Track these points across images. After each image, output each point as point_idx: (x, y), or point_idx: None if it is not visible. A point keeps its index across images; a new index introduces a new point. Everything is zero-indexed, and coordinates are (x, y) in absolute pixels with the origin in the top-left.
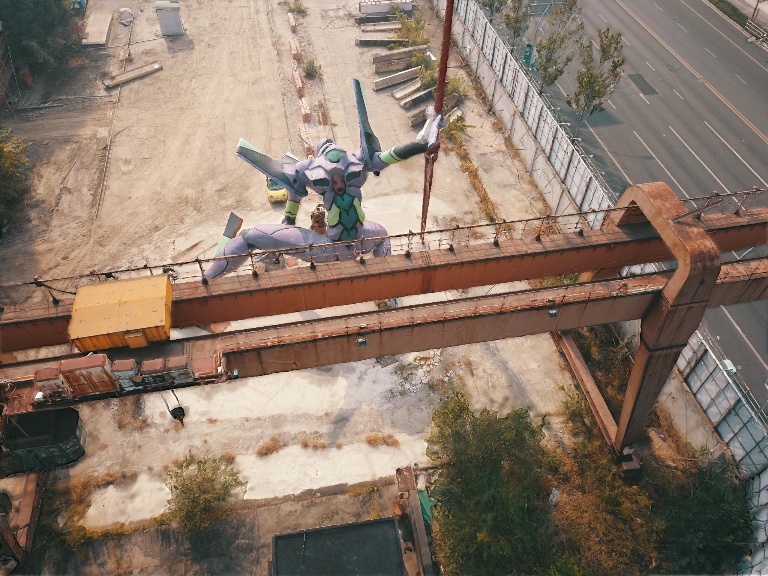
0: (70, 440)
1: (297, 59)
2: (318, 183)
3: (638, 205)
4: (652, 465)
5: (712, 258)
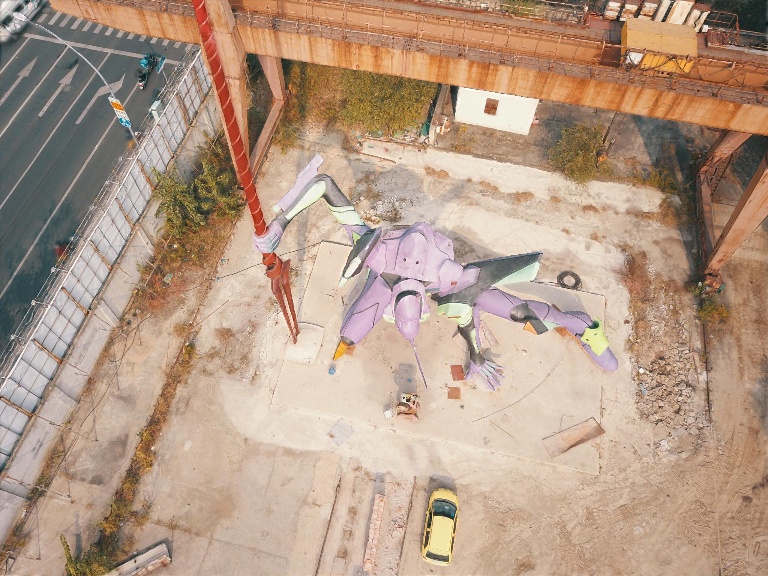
0: None
1: None
2: None
3: None
4: (268, 92)
5: None
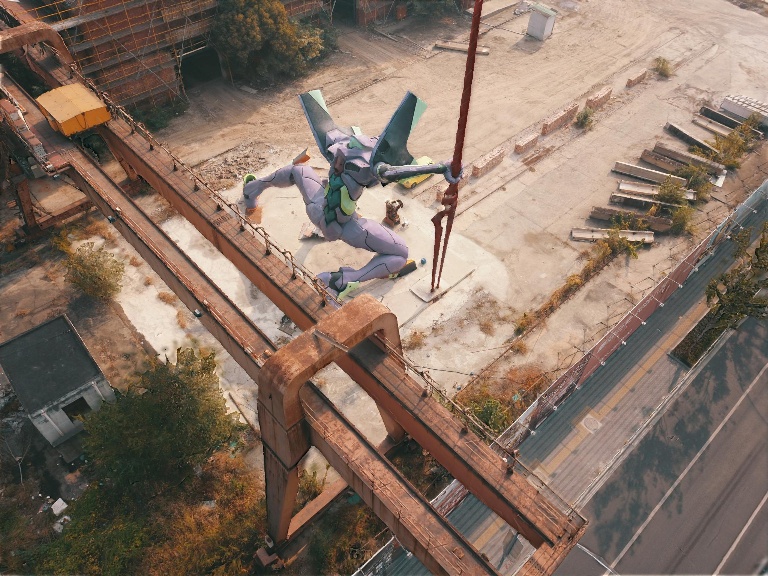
0: (24, 159)
1: (589, 106)
2: (330, 155)
3: None
4: None
5: (281, 380)
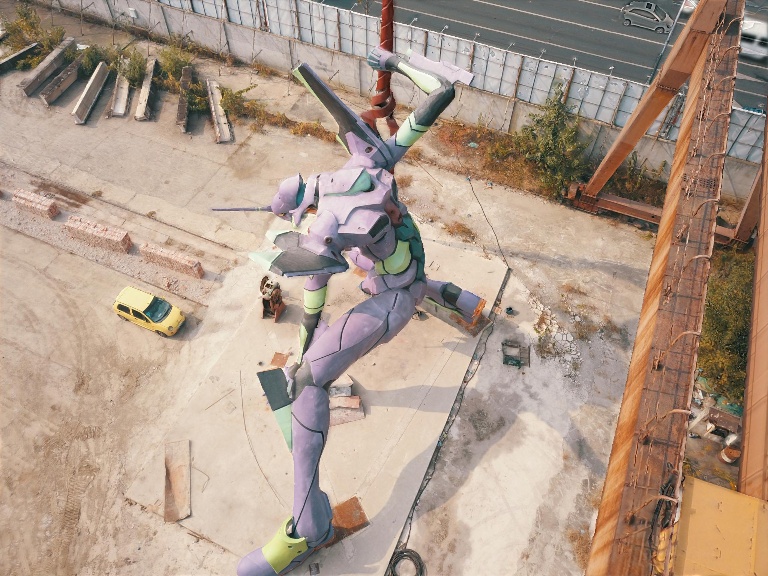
0: None
1: None
2: (374, 230)
3: None
4: None
5: None
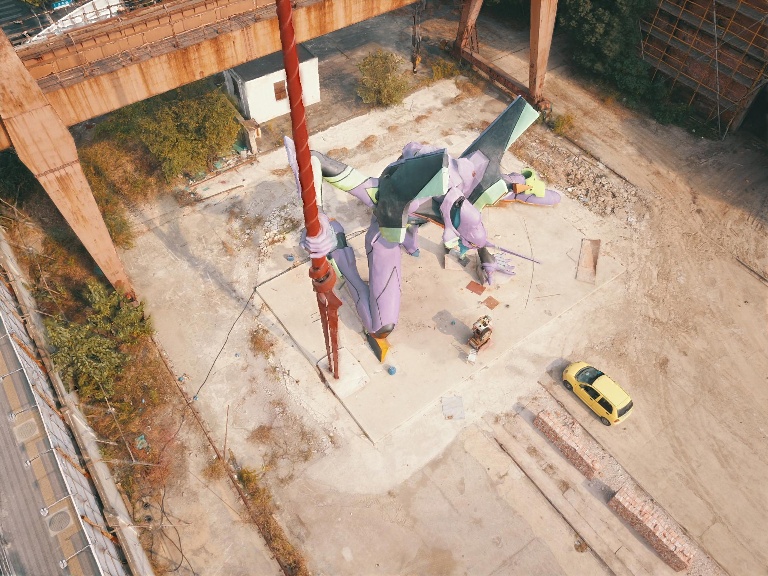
0: None
1: None
2: None
3: None
4: (48, 209)
5: None
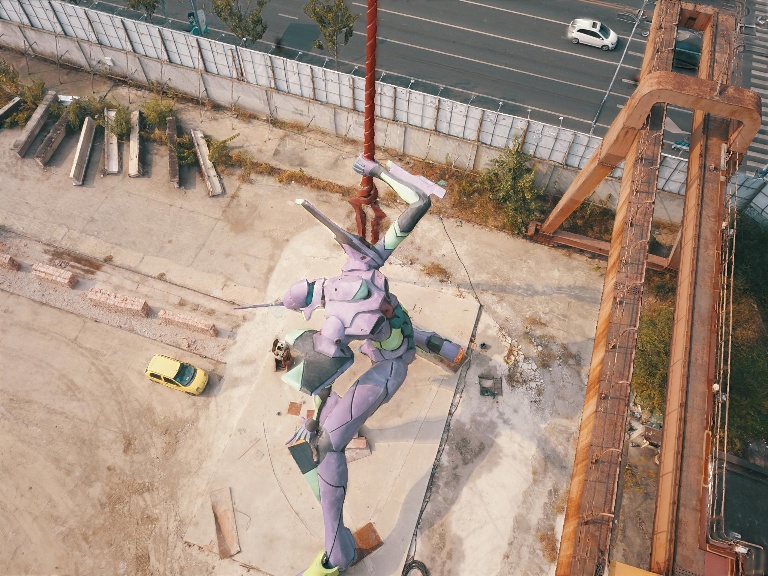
0: None
1: None
2: (374, 329)
3: (668, 103)
4: None
5: (760, 101)
